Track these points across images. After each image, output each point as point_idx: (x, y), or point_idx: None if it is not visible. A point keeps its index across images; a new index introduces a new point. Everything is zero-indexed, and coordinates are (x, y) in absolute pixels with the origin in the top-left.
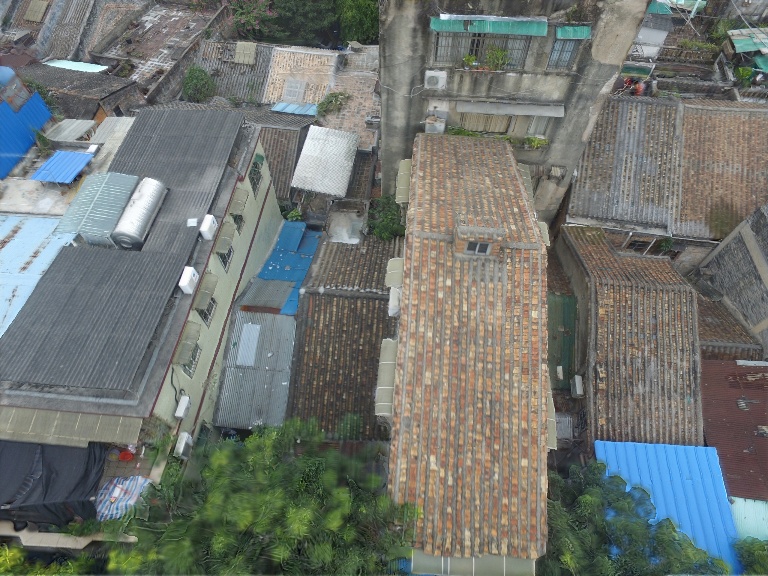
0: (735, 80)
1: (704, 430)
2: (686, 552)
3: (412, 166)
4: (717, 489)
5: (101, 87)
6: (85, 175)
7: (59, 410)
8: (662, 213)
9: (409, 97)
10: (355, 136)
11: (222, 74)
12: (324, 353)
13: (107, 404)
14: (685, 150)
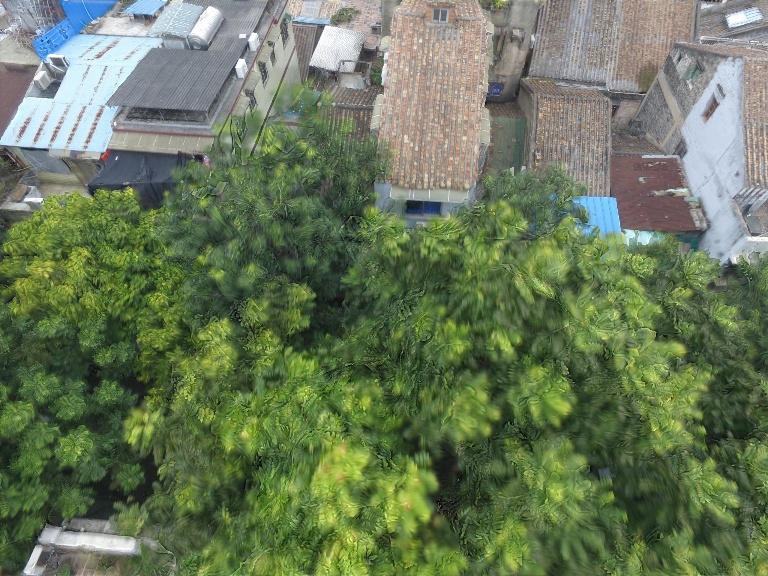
0: None
1: (611, 195)
2: (559, 173)
3: None
4: (613, 220)
5: None
6: None
7: (158, 132)
8: (602, 74)
9: None
10: (362, 34)
11: None
12: None
13: (190, 128)
14: (623, 27)
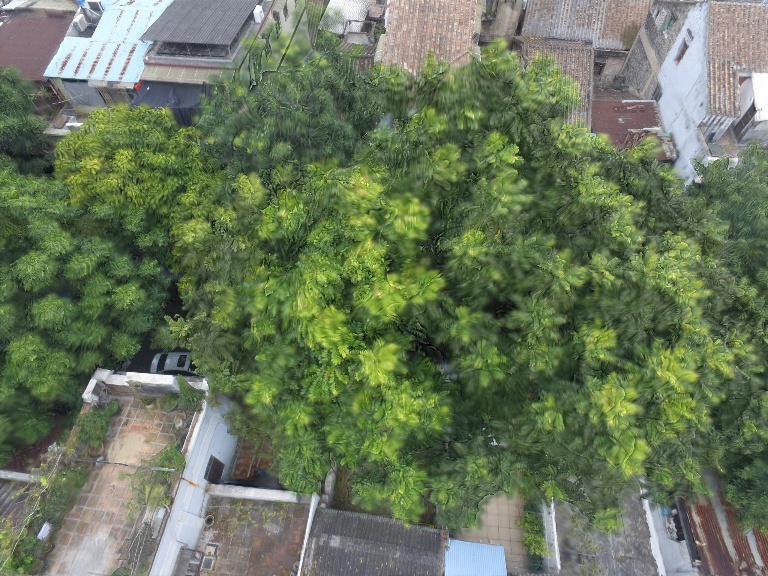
0: None
1: None
2: None
3: None
4: None
5: None
6: None
7: (185, 66)
8: (589, 33)
9: None
10: (367, 3)
11: None
12: None
13: (214, 62)
14: None
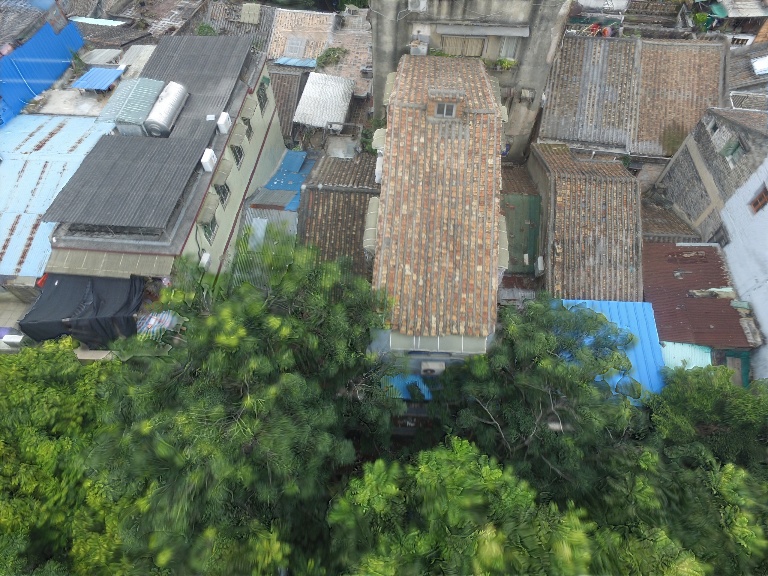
0: (694, 26)
1: (644, 294)
2: (600, 321)
3: (397, 72)
4: (650, 333)
5: (120, 36)
6: (117, 86)
7: (106, 251)
8: (621, 134)
9: (396, 21)
10: (351, 81)
11: (229, 33)
12: (322, 238)
13: (145, 245)
14: (643, 80)
